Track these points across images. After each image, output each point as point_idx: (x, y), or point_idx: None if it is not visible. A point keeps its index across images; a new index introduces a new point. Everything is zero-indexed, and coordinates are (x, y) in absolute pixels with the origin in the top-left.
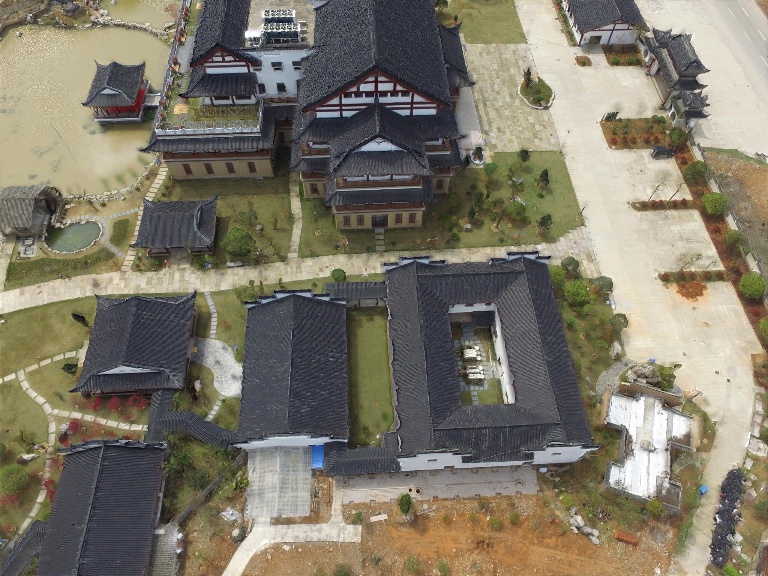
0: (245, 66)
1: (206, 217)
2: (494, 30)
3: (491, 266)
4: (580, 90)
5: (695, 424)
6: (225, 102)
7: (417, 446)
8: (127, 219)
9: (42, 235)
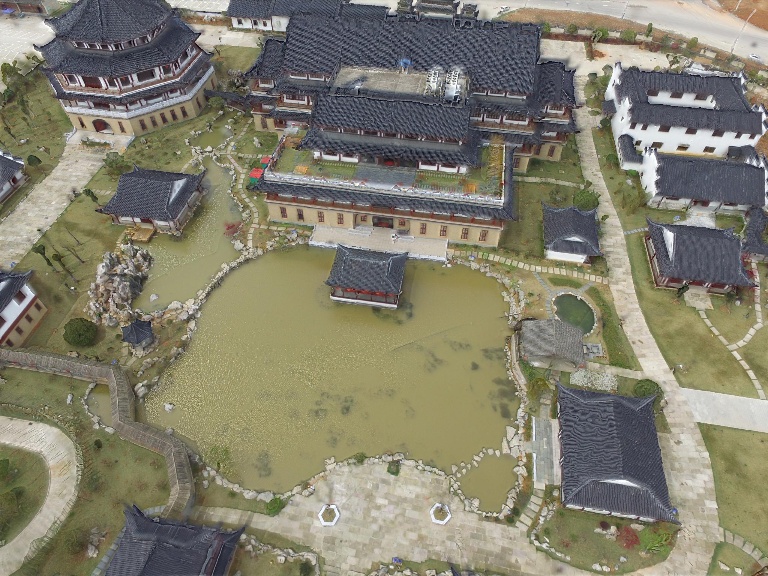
0: None
1: None
2: None
3: (623, 84)
4: None
5: (699, 60)
6: None
7: (756, 124)
8: (548, 278)
9: None
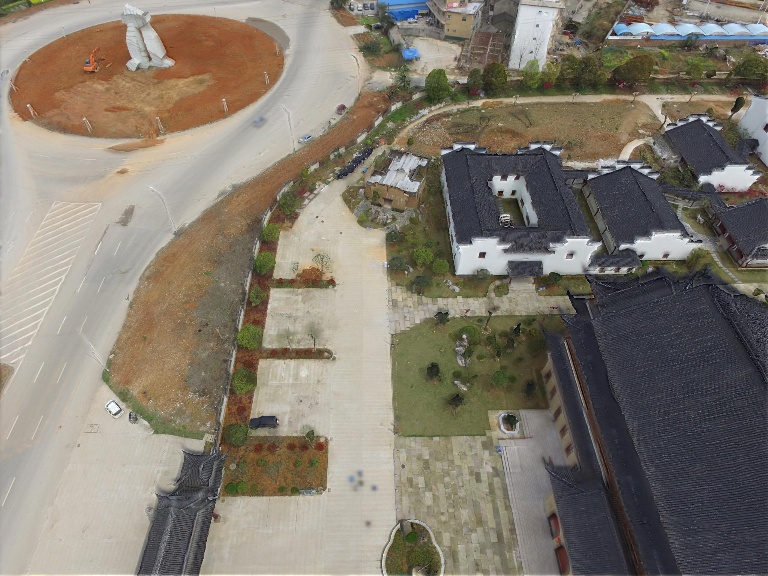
0: None
1: None
2: None
3: None
4: (334, 572)
5: None
6: None
7: None
8: None
9: None
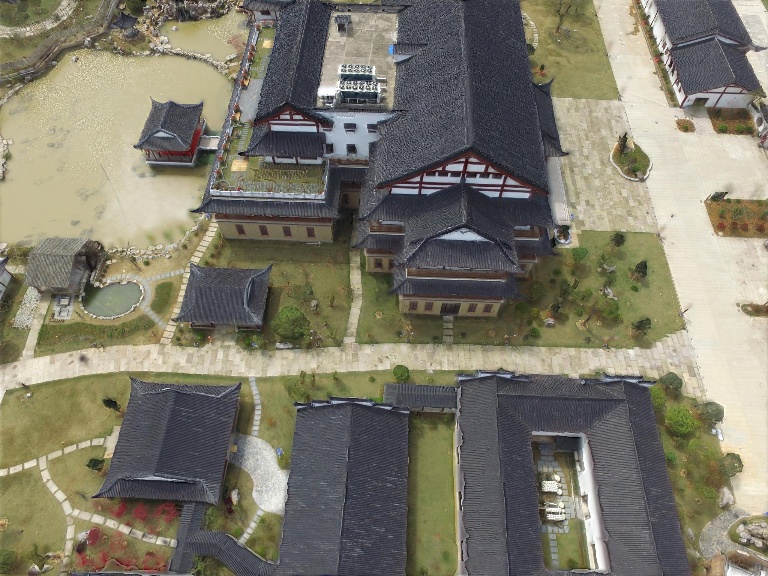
0: (314, 125)
1: (257, 291)
2: (584, 83)
3: (584, 387)
4: (681, 160)
5: None
6: (288, 161)
7: None
8: (171, 282)
9: (79, 295)
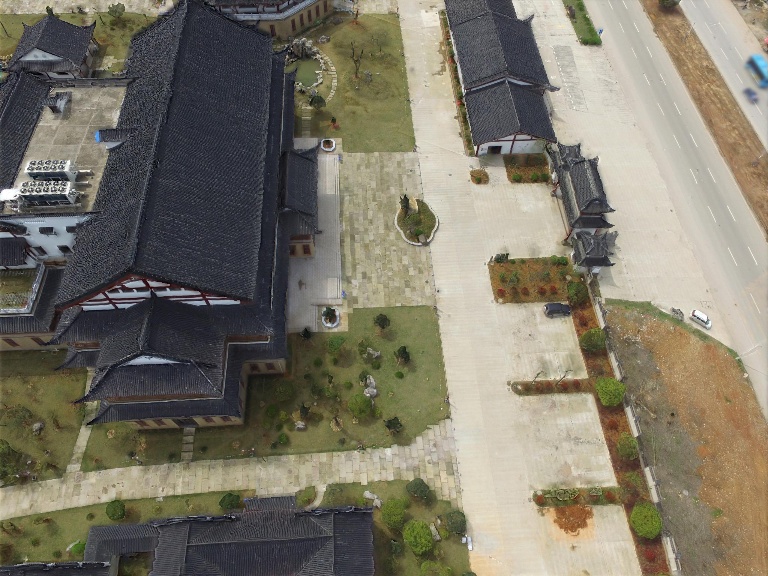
0: None
1: None
2: (379, 134)
3: (294, 521)
4: (470, 217)
5: None
6: None
7: None
8: None
9: None
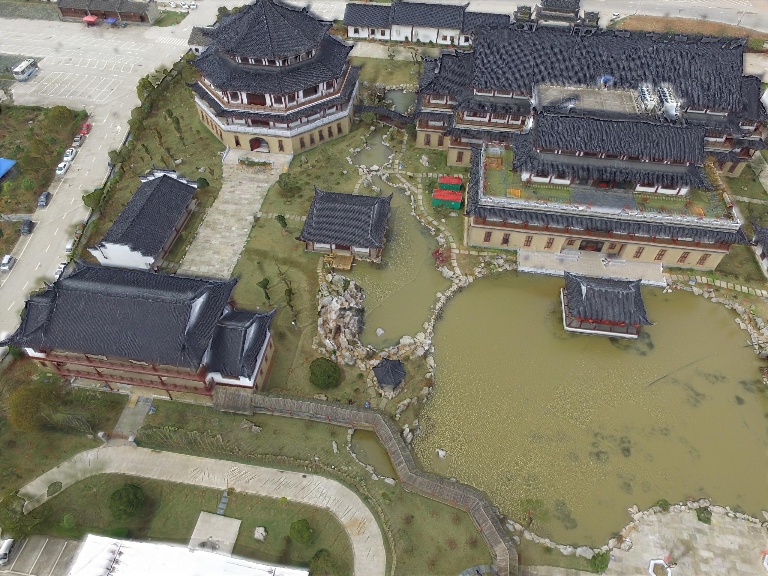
0: None
1: None
2: None
3: None
4: None
5: None
6: None
7: None
8: None
9: None
